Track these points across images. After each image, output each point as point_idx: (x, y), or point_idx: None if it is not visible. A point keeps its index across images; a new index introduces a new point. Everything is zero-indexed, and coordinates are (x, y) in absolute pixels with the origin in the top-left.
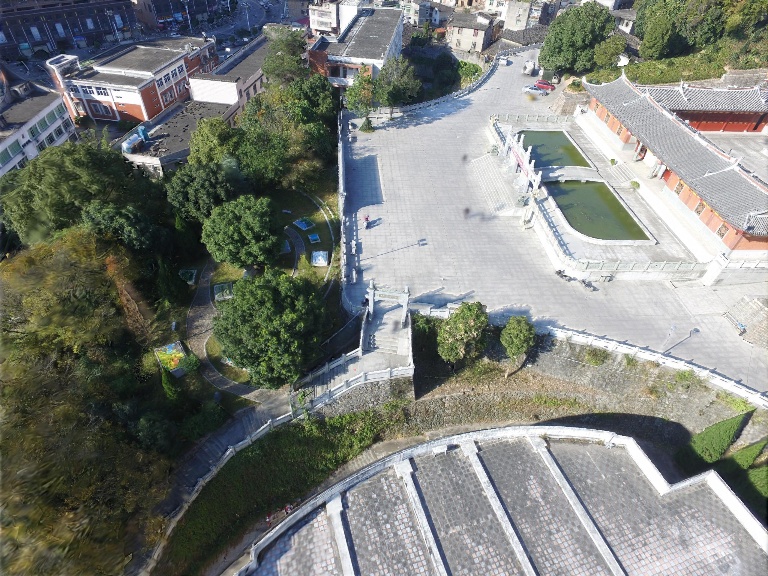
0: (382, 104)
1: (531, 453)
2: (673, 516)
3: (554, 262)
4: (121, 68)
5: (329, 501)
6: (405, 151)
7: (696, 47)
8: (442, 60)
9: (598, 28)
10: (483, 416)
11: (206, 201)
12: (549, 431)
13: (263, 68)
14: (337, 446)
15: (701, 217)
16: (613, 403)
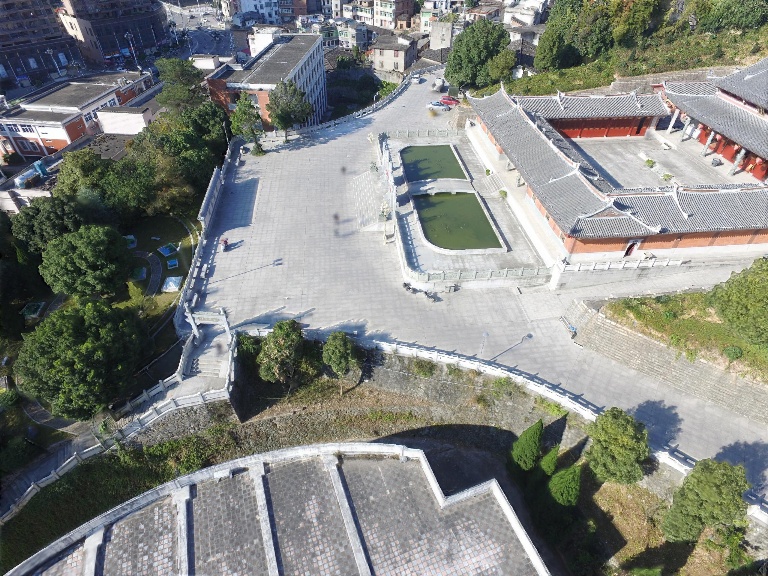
0: (277, 127)
1: (320, 472)
2: (447, 529)
3: (403, 275)
4: (48, 105)
5: (90, 535)
6: (290, 172)
7: (589, 57)
8: (364, 81)
9: (493, 44)
10: (321, 435)
11: (51, 233)
12: (341, 448)
13: (156, 98)
14: (162, 475)
15: (549, 222)
16: (448, 414)
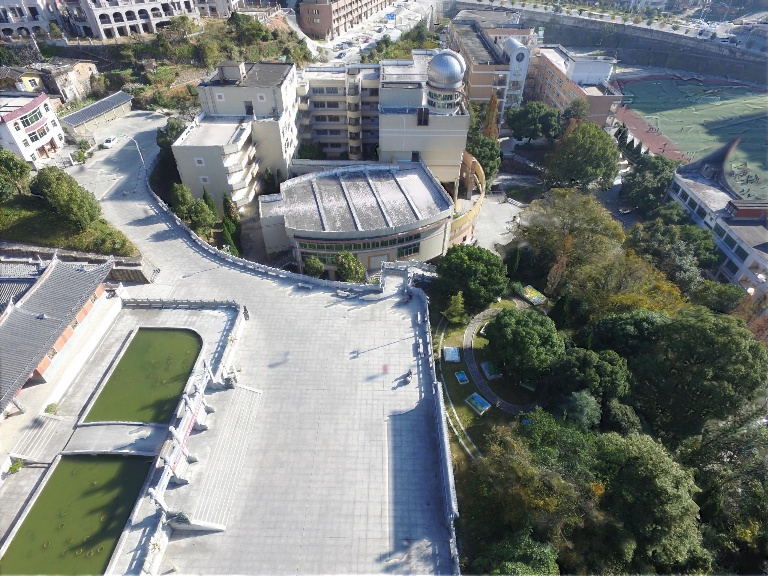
0: None
1: None
2: None
3: None
4: None
5: None
6: (333, 575)
7: None
8: None
9: None
10: None
11: None
12: None
13: None
14: None
15: None
16: None
